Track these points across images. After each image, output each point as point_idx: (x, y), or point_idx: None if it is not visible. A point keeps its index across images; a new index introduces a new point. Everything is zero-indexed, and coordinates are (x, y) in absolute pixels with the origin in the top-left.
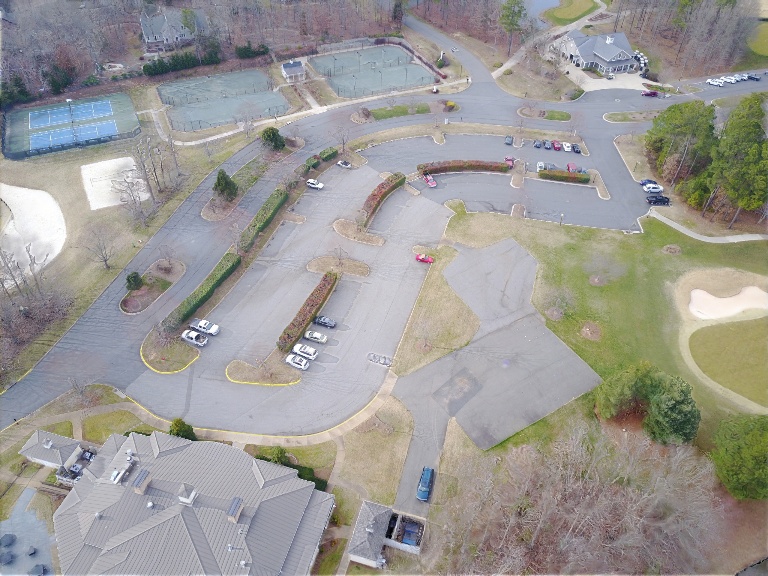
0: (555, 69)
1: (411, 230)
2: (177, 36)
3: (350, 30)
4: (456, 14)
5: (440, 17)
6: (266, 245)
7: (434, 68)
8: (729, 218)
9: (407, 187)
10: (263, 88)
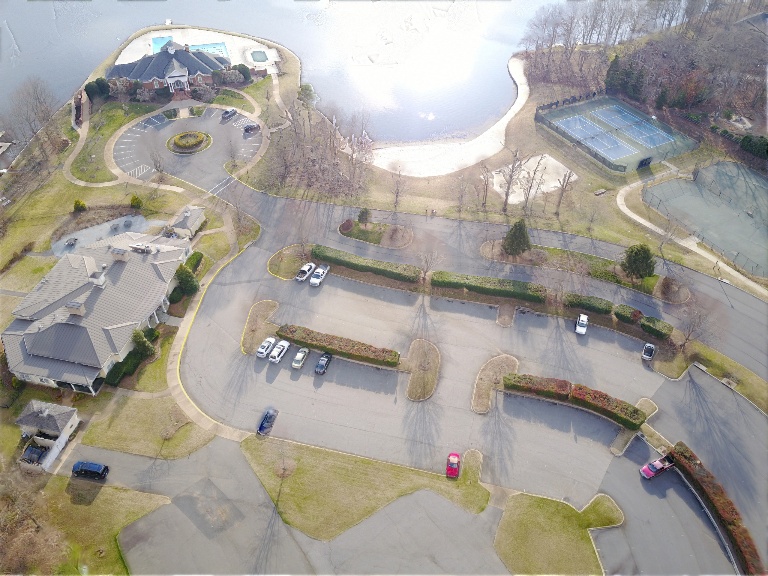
0: None
1: (517, 446)
2: None
3: None
4: None
5: None
6: (450, 299)
7: None
8: None
9: (625, 435)
10: None
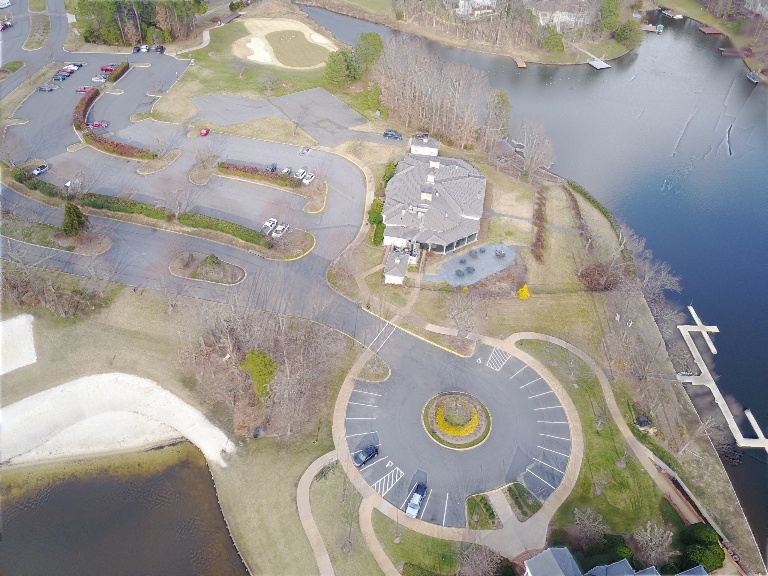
0: None
1: (166, 137)
2: None
3: None
4: None
5: None
6: None
7: None
8: (186, 34)
9: None
10: None
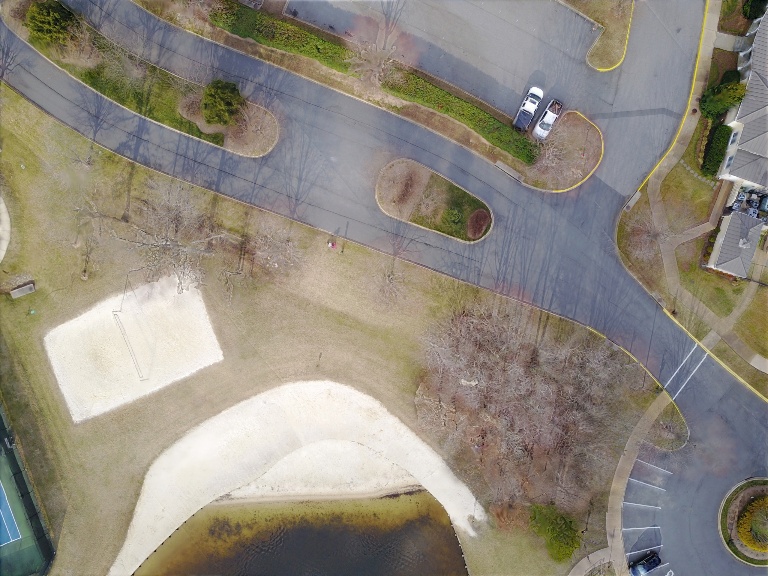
0: None
1: None
2: None
3: None
4: None
5: None
6: (348, 38)
7: None
8: None
9: None
10: None
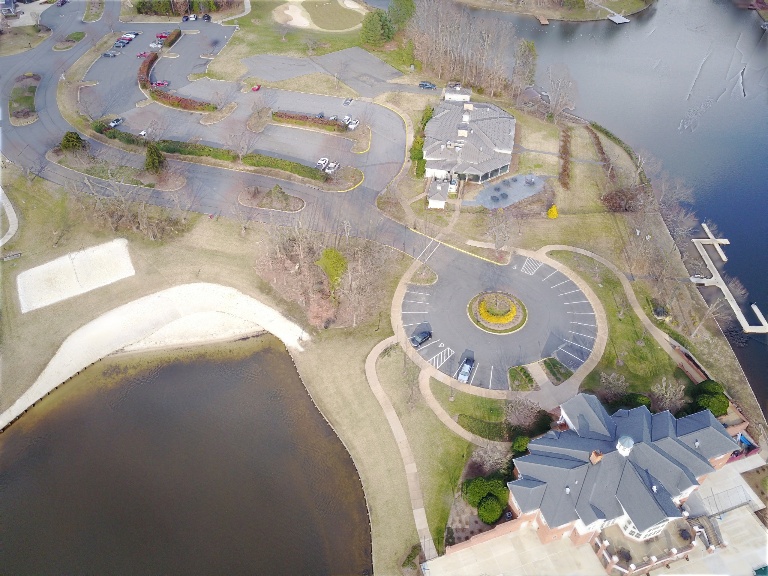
0: None
1: (222, 93)
2: None
3: None
4: None
5: None
6: None
7: None
8: None
9: None
10: None
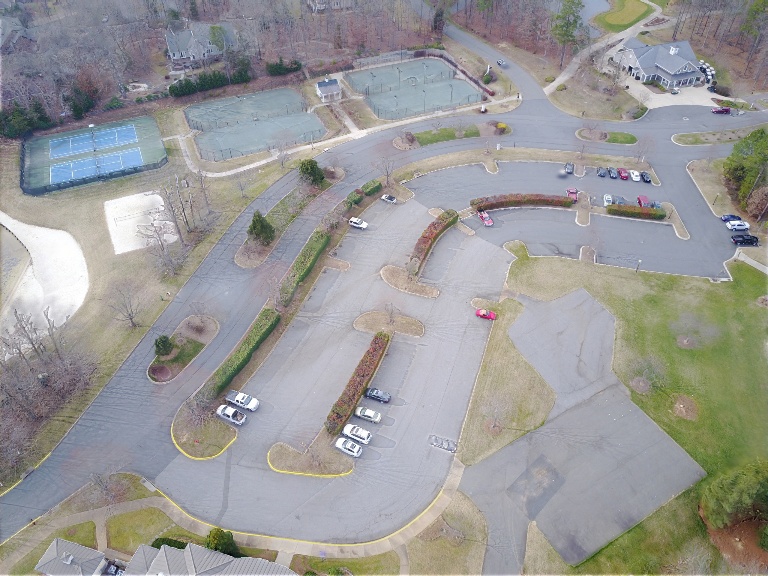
0: (614, 84)
1: (468, 279)
2: (204, 52)
3: (387, 42)
4: (501, 22)
5: (483, 25)
6: (307, 297)
7: (480, 84)
8: None
9: (460, 226)
10: (297, 109)
